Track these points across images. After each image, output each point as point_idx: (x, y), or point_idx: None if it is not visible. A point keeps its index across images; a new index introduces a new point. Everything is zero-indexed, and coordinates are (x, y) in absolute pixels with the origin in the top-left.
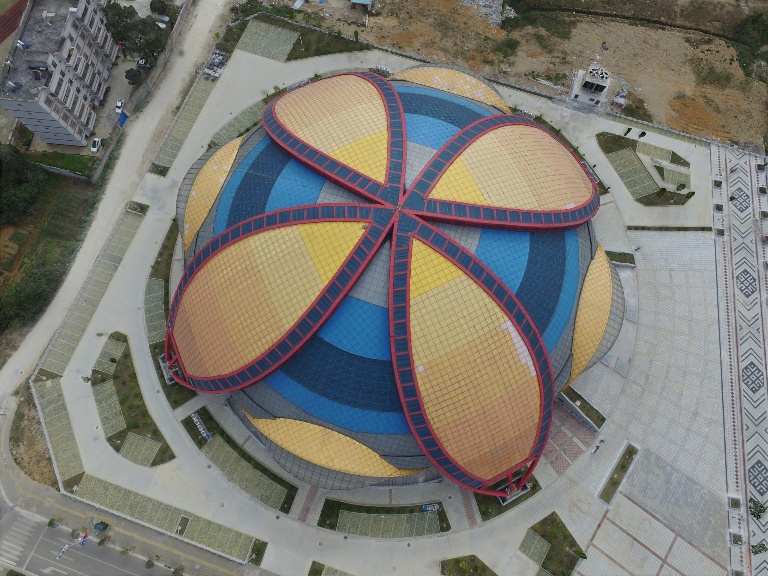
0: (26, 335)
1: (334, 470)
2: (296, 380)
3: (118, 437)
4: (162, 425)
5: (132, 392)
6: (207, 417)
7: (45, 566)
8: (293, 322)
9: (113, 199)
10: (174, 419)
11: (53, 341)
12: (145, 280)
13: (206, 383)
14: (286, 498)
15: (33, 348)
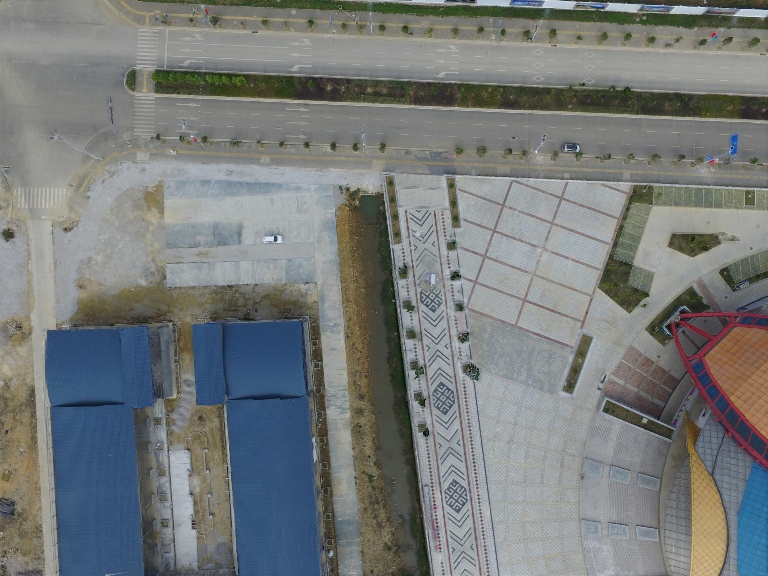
0: None
1: None
2: None
3: None
4: None
5: None
6: None
7: None
8: None
9: None
10: None
11: None
12: None
13: None
14: None
15: None
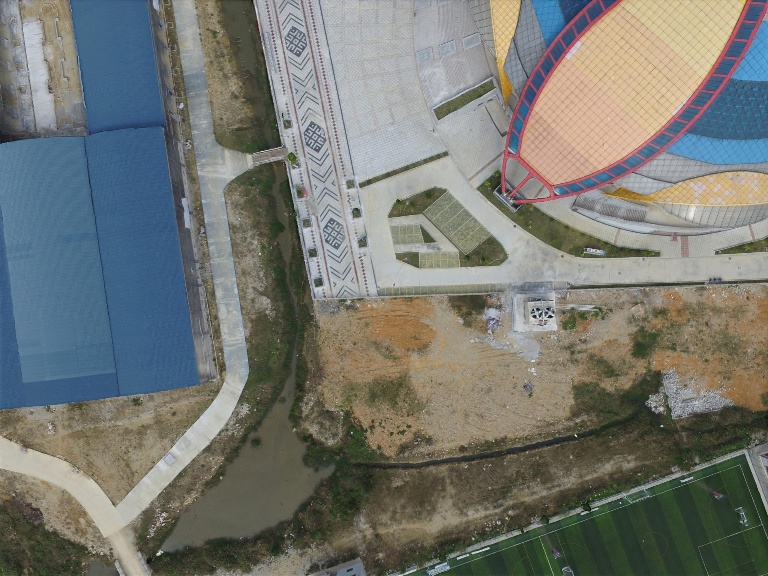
0: None
1: None
2: None
3: None
4: None
5: None
6: None
7: None
8: None
9: None
10: None
11: None
12: None
13: None
14: None
15: None
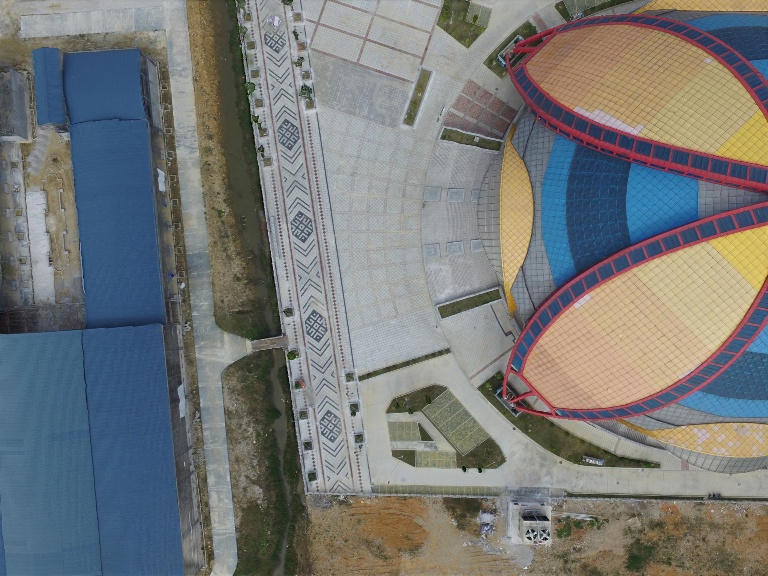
0: None
1: None
2: None
3: None
4: None
5: None
6: None
7: None
8: None
9: None
10: None
11: None
12: None
13: None
14: None
15: None
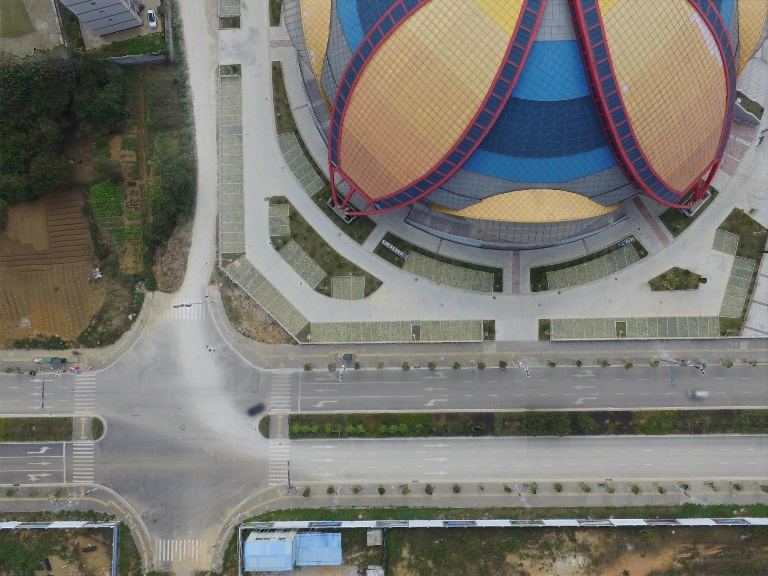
0: (191, 230)
1: (556, 222)
2: (497, 152)
3: (324, 284)
4: (358, 261)
5: (316, 243)
6: (395, 239)
7: (316, 402)
8: (487, 88)
9: (200, 71)
10: (366, 252)
11: (220, 226)
12: (275, 139)
13: (401, 196)
14: (495, 280)
15: (204, 239)
